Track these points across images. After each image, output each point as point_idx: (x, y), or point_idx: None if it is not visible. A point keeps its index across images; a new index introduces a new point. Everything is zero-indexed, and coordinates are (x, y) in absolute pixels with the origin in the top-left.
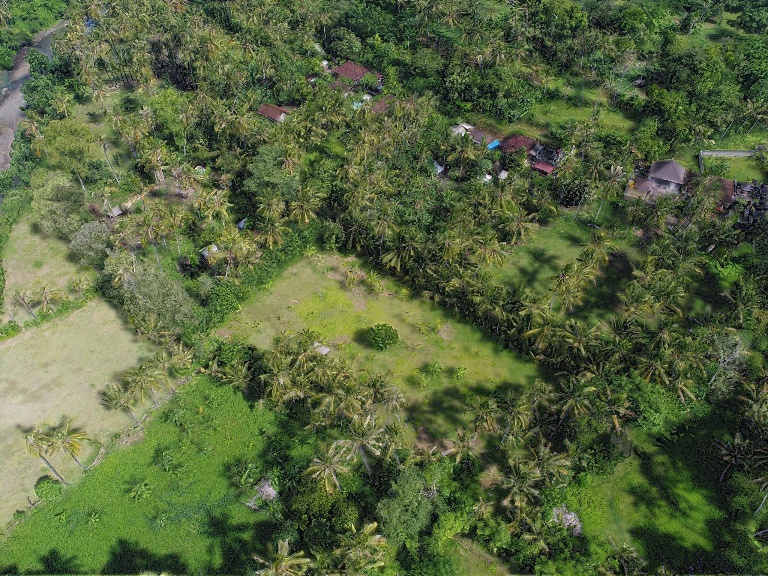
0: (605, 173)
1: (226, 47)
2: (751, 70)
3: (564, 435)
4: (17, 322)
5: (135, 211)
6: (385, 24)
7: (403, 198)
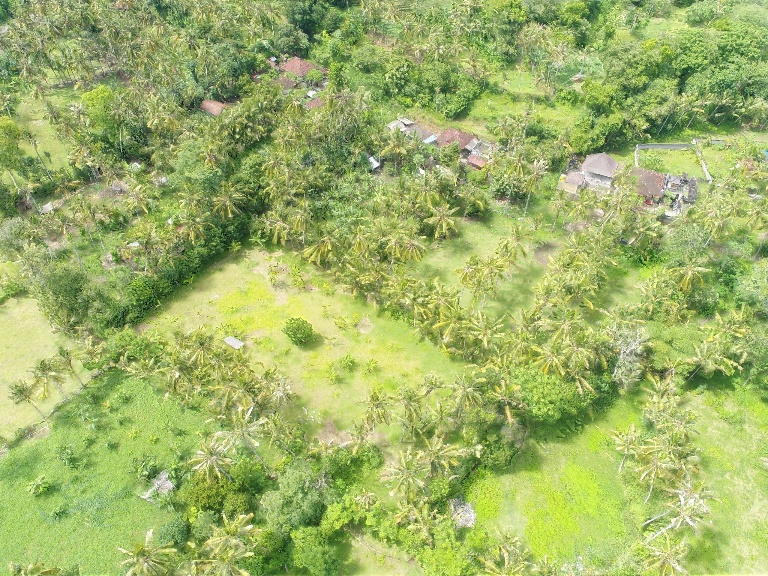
0: (528, 167)
1: (174, 44)
2: (688, 64)
3: (463, 427)
4: None
5: None
6: (332, 20)
7: (334, 193)
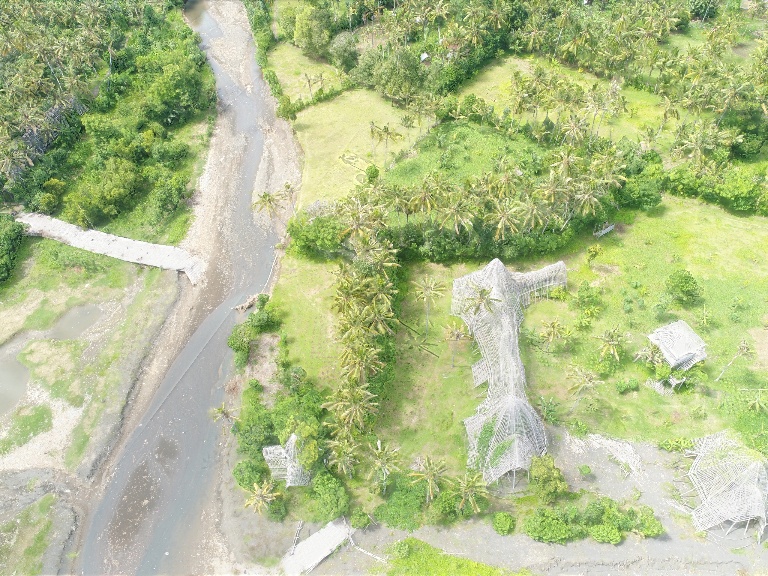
0: None
1: None
2: None
3: None
4: None
5: None
6: None
7: None
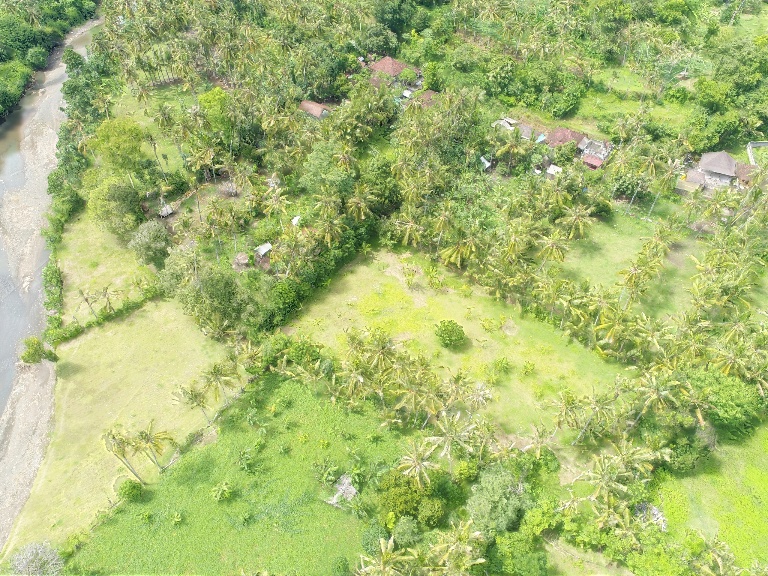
0: (663, 166)
1: (262, 45)
2: None
3: (642, 430)
4: (79, 323)
5: (185, 210)
6: (421, 19)
7: (454, 194)
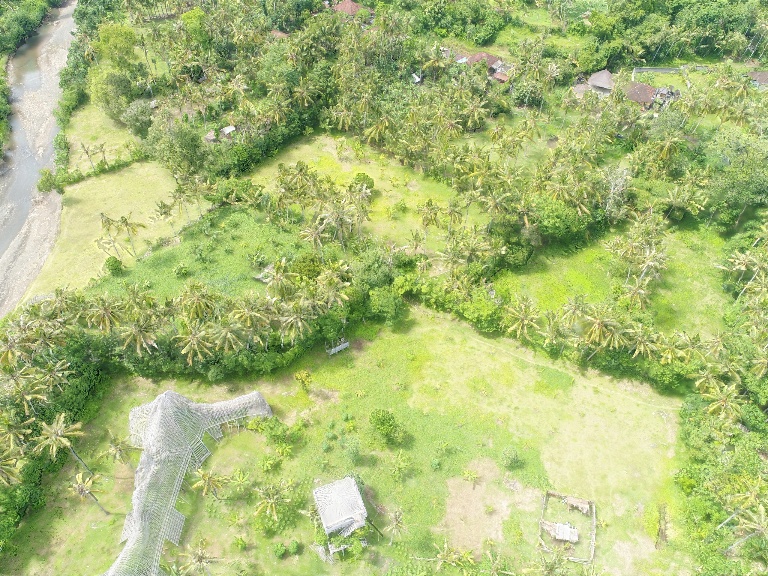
0: (543, 70)
1: None
2: (678, 3)
3: None
4: None
5: None
6: None
7: (385, 96)
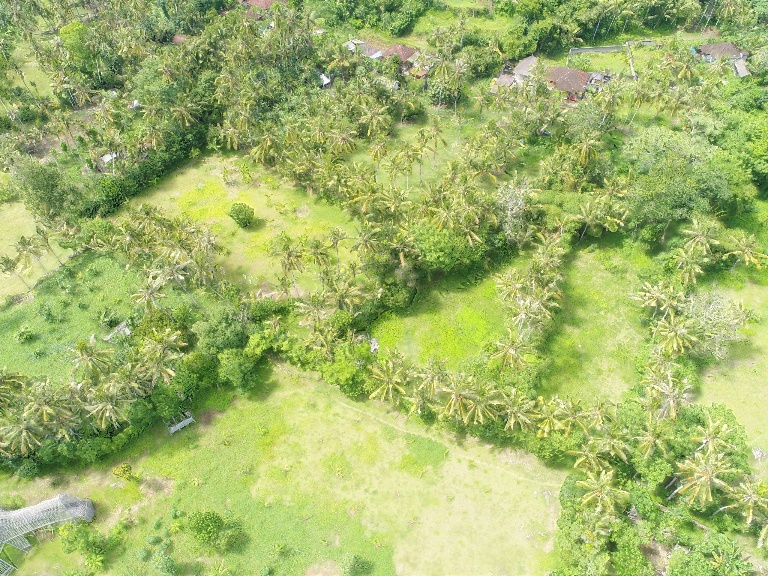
0: (450, 66)
1: None
2: None
3: None
4: None
5: None
6: None
7: (284, 105)
